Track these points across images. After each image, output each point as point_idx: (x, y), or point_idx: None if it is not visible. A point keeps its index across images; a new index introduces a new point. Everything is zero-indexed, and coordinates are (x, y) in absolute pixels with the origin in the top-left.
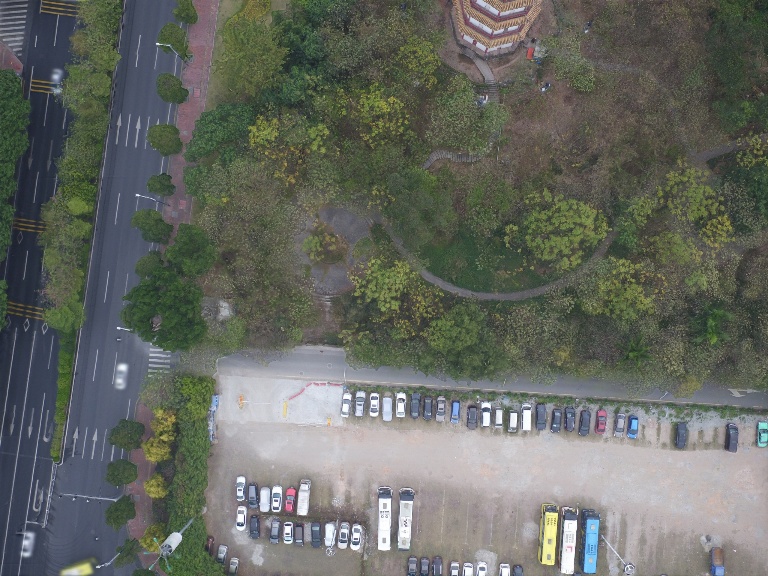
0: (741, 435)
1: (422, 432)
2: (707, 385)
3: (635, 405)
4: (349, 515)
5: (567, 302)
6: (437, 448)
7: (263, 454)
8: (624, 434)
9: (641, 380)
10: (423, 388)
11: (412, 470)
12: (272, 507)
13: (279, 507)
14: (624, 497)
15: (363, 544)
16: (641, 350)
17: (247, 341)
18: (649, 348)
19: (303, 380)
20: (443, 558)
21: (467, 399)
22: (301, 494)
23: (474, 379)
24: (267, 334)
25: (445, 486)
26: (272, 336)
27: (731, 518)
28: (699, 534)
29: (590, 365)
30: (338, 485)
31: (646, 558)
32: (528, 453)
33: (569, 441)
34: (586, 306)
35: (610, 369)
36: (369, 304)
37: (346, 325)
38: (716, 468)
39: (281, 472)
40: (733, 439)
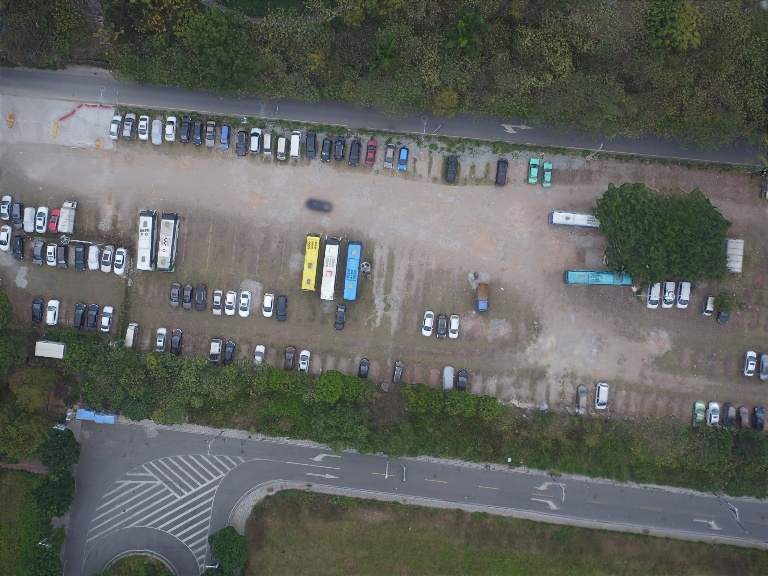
0: (513, 172)
1: (192, 158)
2: (478, 116)
3: (407, 137)
4: (115, 239)
5: (328, 12)
6: (206, 175)
7: (31, 175)
8: (395, 166)
9: (396, 89)
10: (194, 113)
11: (180, 196)
12: (36, 226)
13: (43, 227)
14: (393, 230)
15: (128, 269)
16: (388, 48)
17: (1, 37)
18: (402, 53)
19: (75, 102)
20: (208, 287)
21: (238, 126)
22: (63, 210)
23: (229, 84)
24: (21, 29)
25: (213, 213)
26: (26, 32)
27: (500, 256)
28: (467, 271)
29: (346, 73)
30: (105, 209)
31: (413, 293)
32: (298, 183)
33: (339, 172)
34: (347, 17)
35: (367, 79)
36: (125, 3)
37: (116, 42)
38: (486, 204)
39: (49, 194)
40: (501, 171)
